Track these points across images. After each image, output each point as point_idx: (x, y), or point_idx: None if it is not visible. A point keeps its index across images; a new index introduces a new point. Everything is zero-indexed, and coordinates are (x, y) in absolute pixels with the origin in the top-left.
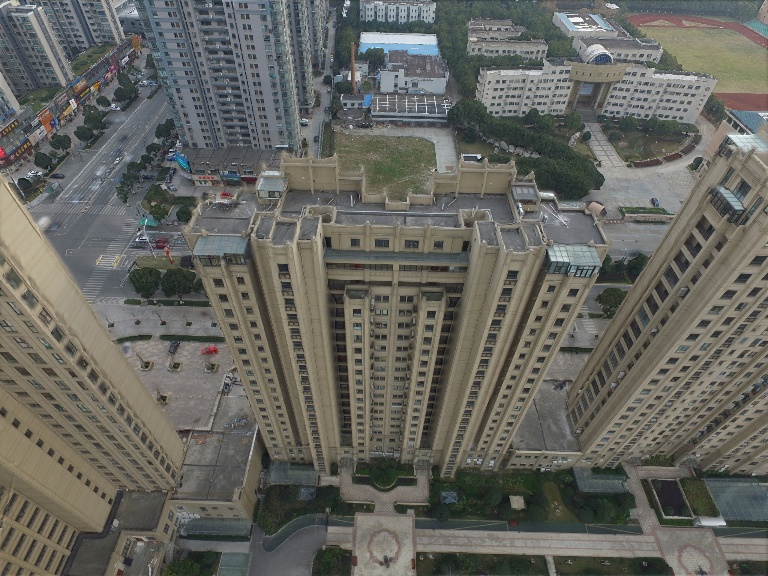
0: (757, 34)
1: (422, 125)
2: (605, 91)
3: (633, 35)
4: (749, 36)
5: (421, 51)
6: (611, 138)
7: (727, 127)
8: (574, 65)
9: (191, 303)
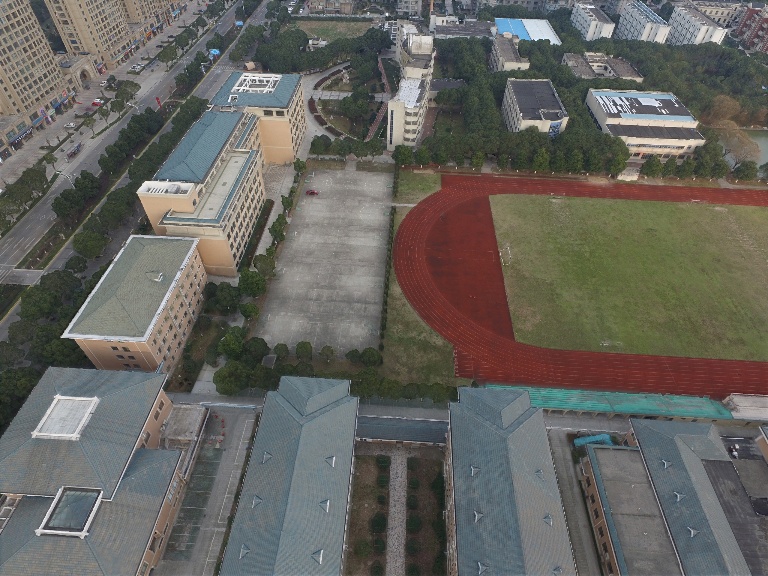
0: None
1: None
2: None
3: None
4: None
5: None
6: None
7: None
8: None
9: (234, 2)
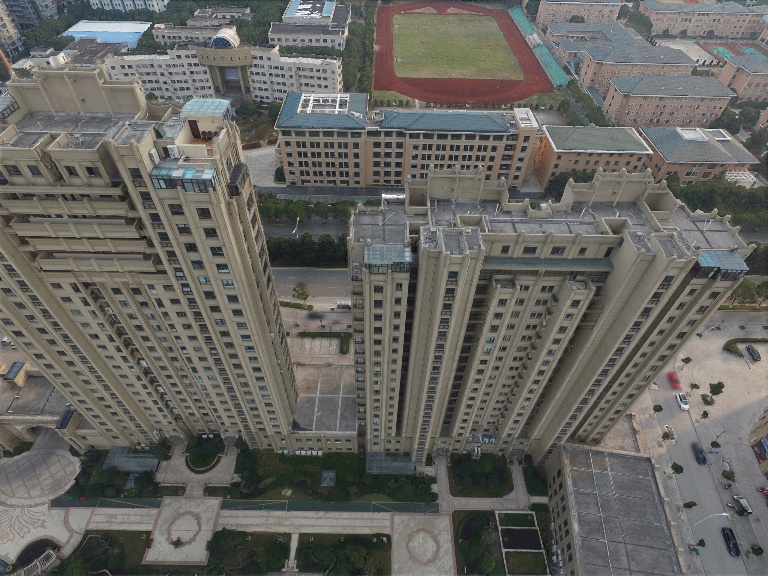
0: (511, 20)
1: None
2: (247, 76)
3: None
4: (500, 22)
5: (121, 39)
6: None
7: None
8: (196, 49)
9: None
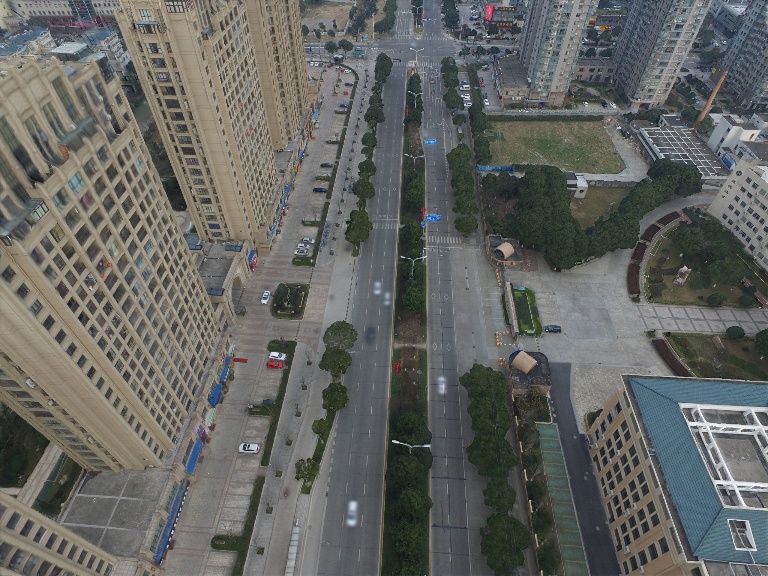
0: None
1: None
2: None
3: None
4: None
5: None
6: None
7: None
8: None
9: None
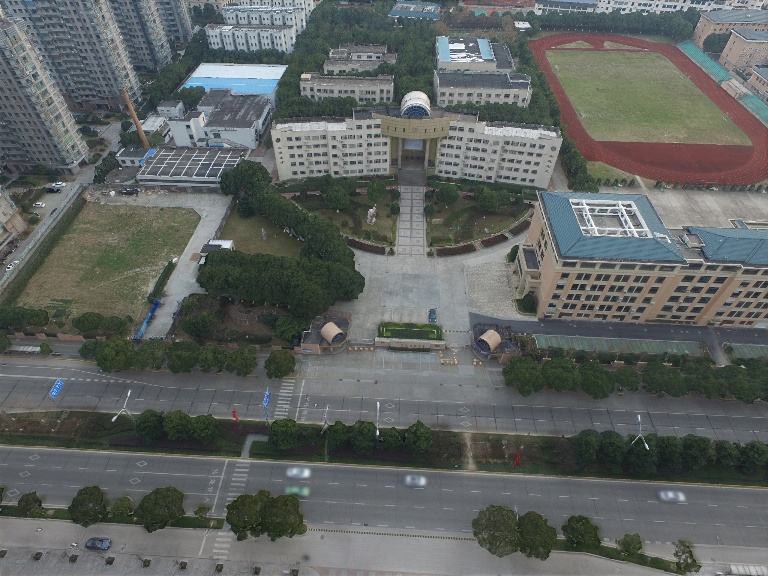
0: (687, 59)
1: (201, 191)
2: (434, 147)
3: (527, 63)
4: (676, 61)
5: (255, 88)
6: (425, 212)
7: (538, 213)
8: (383, 118)
9: None
